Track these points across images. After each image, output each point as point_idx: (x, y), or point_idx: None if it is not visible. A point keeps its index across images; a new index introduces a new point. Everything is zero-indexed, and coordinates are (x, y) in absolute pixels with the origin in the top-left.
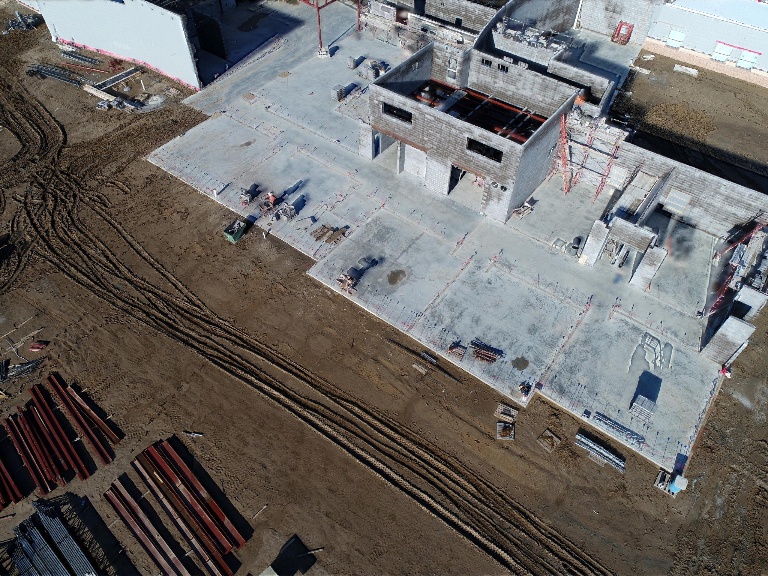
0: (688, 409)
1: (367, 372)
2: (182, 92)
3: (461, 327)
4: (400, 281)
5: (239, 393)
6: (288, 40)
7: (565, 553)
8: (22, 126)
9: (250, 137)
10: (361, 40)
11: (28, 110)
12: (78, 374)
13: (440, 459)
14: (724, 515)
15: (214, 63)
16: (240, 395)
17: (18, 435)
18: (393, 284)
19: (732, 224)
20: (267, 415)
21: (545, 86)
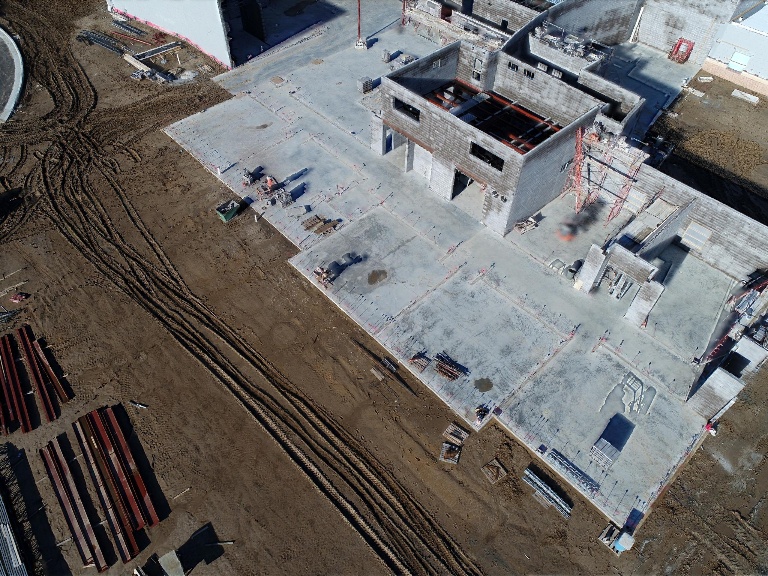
0: (657, 462)
1: (323, 370)
2: (214, 70)
3: (430, 338)
4: (380, 282)
5: (192, 371)
6: (330, 28)
7: None
8: (60, 88)
9: (268, 120)
10: (402, 34)
11: (69, 73)
12: (48, 330)
13: (375, 471)
14: None
15: (252, 44)
16: (193, 374)
17: None
18: (372, 284)
19: (754, 268)
20: (214, 398)
21: (570, 97)
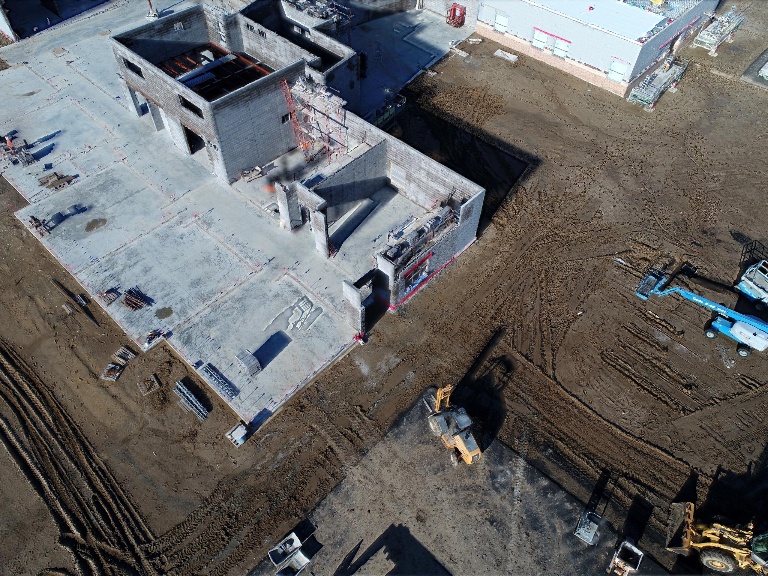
0: (300, 369)
1: (17, 308)
2: None
3: (128, 275)
4: (96, 229)
5: None
6: (129, 2)
7: (101, 486)
8: None
9: (37, 88)
10: None
11: None
12: None
13: (37, 391)
14: (277, 469)
15: (45, 18)
16: None
17: None
18: (88, 231)
19: (439, 201)
20: None
21: (294, 53)
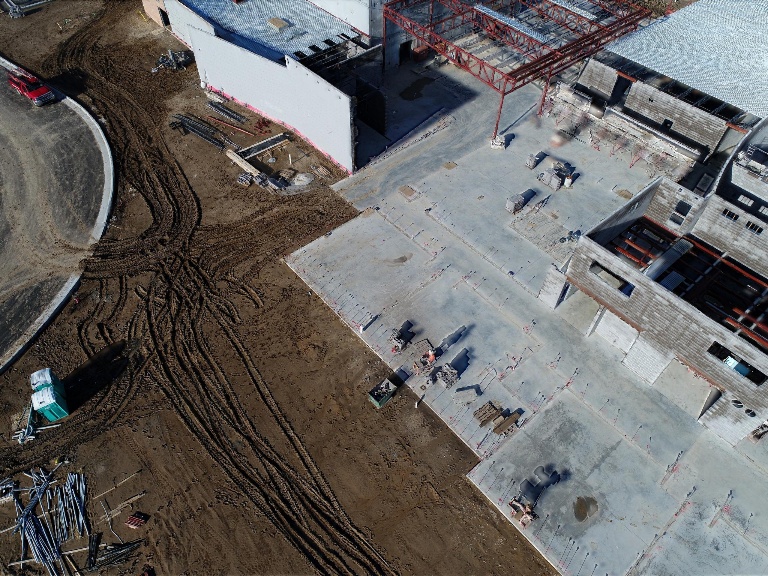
0: None
1: None
2: (332, 173)
3: None
4: (590, 517)
5: None
6: (456, 118)
7: None
8: (157, 193)
9: (406, 250)
10: (541, 129)
11: (165, 173)
12: None
13: None
14: None
15: (370, 139)
16: None
17: None
18: (581, 520)
19: None
20: None
21: None
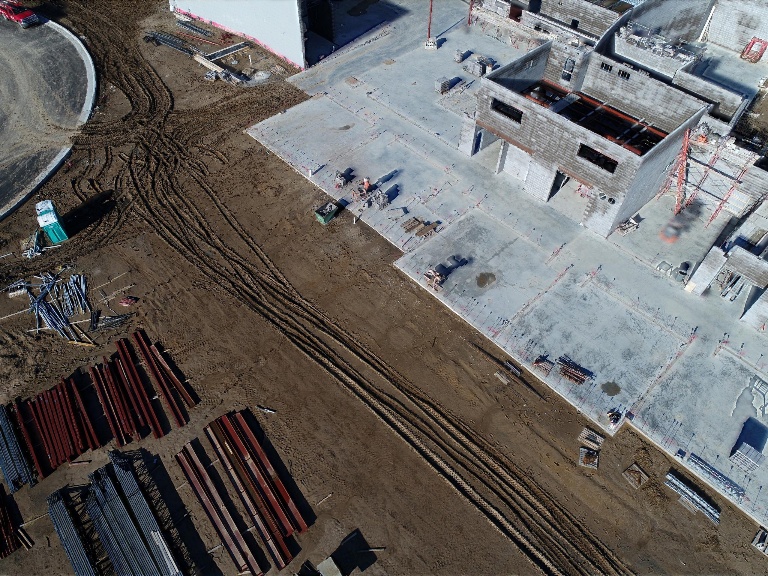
0: None
1: (446, 374)
2: (287, 70)
3: (550, 341)
4: (489, 284)
5: (315, 376)
6: (396, 28)
7: None
8: (134, 89)
9: (349, 121)
10: (470, 34)
11: (141, 74)
12: (162, 334)
13: (515, 476)
14: None
15: (321, 44)
16: (316, 378)
17: (101, 385)
18: (481, 287)
19: None
20: (340, 402)
21: (669, 97)
